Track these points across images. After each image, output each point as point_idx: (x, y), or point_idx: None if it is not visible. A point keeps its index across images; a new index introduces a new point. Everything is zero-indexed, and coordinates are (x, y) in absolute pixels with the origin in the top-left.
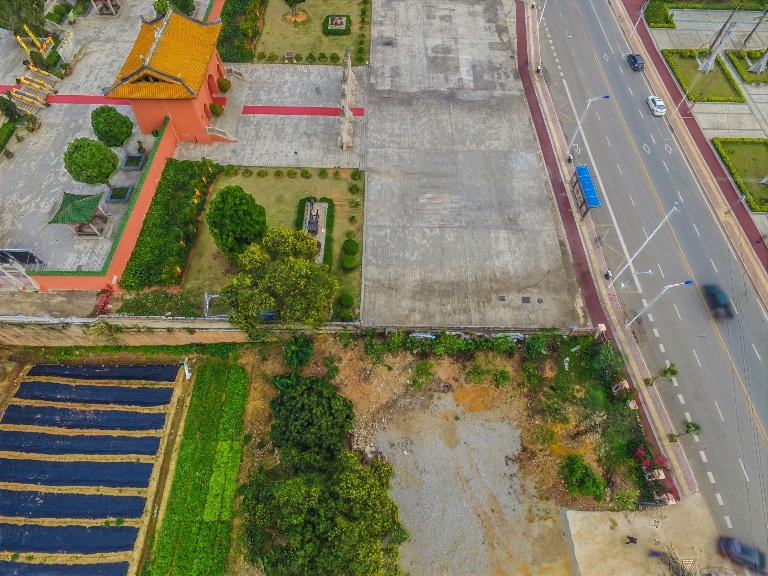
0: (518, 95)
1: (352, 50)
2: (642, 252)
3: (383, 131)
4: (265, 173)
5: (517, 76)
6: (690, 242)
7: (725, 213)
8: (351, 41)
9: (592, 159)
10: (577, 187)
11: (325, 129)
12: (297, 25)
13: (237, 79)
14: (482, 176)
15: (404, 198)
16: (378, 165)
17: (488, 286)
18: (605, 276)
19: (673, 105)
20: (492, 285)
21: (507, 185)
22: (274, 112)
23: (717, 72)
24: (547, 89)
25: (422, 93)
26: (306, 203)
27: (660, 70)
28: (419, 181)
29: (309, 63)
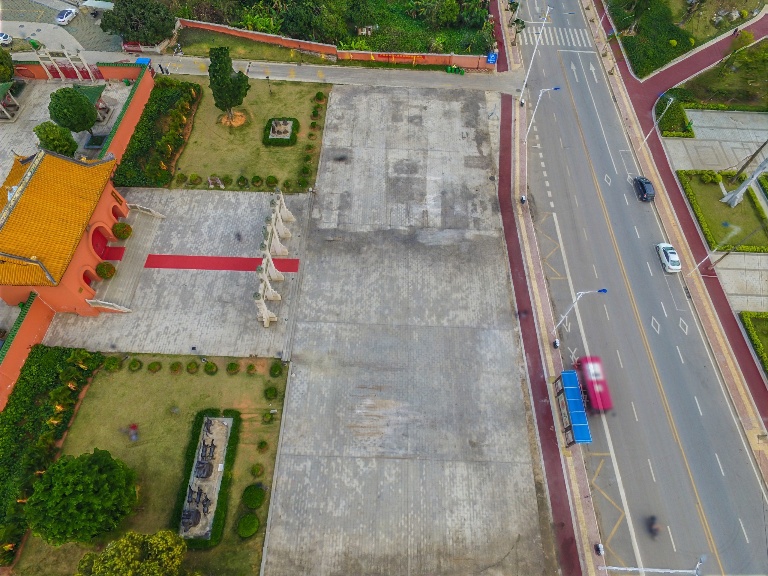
0: (496, 237)
1: (295, 169)
2: (646, 503)
3: (320, 295)
4: (158, 366)
5: (496, 207)
6: (711, 487)
7: (758, 437)
8: (296, 155)
9: (585, 341)
10: (562, 399)
11: (246, 293)
12: (233, 131)
13: (144, 216)
14: (441, 369)
15: (335, 406)
16: (307, 351)
17: (434, 565)
18: (595, 548)
19: (690, 256)
20: (440, 563)
21: (472, 385)
22: (185, 265)
23: (746, 206)
24: (533, 228)
25: (375, 234)
26: (204, 419)
27: (674, 201)
28: (358, 377)
29: (239, 189)
